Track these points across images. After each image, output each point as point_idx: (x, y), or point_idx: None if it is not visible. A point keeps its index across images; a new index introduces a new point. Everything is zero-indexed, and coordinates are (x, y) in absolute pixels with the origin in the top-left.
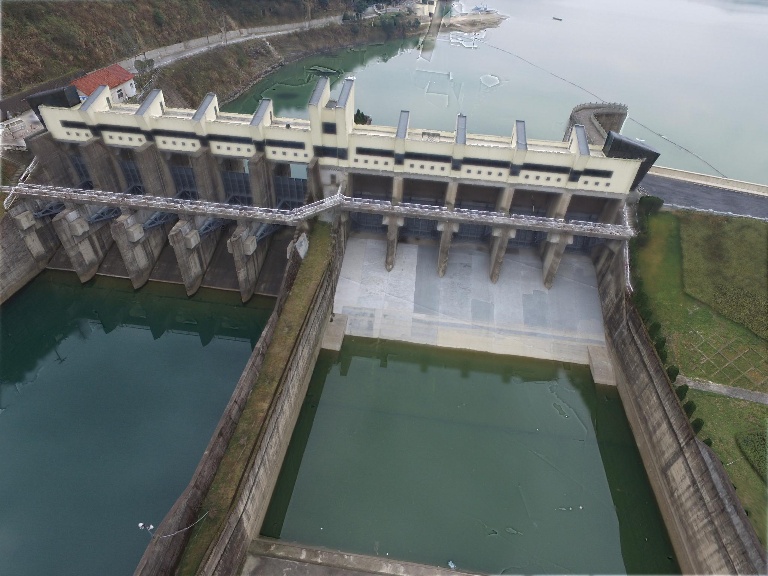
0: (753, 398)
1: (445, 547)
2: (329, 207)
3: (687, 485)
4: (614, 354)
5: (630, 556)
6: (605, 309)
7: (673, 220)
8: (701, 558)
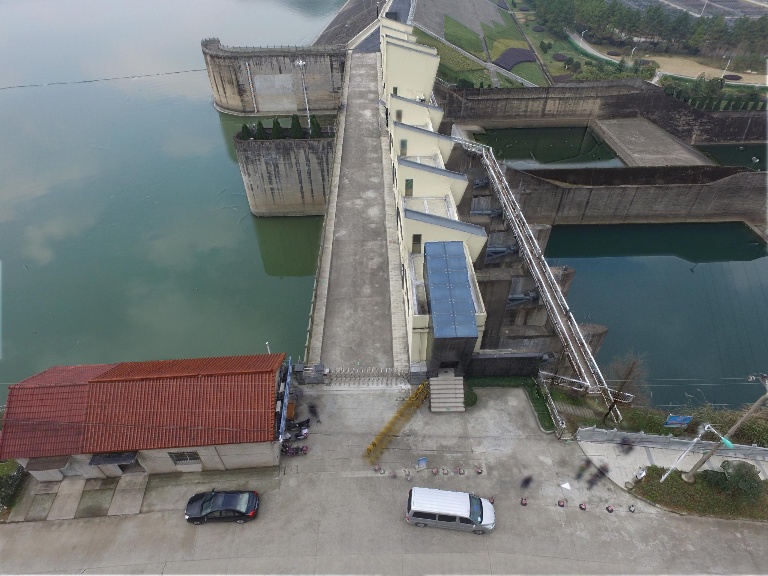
0: (498, 86)
1: None
2: None
3: (558, 103)
4: (469, 121)
5: None
6: None
7: None
8: None
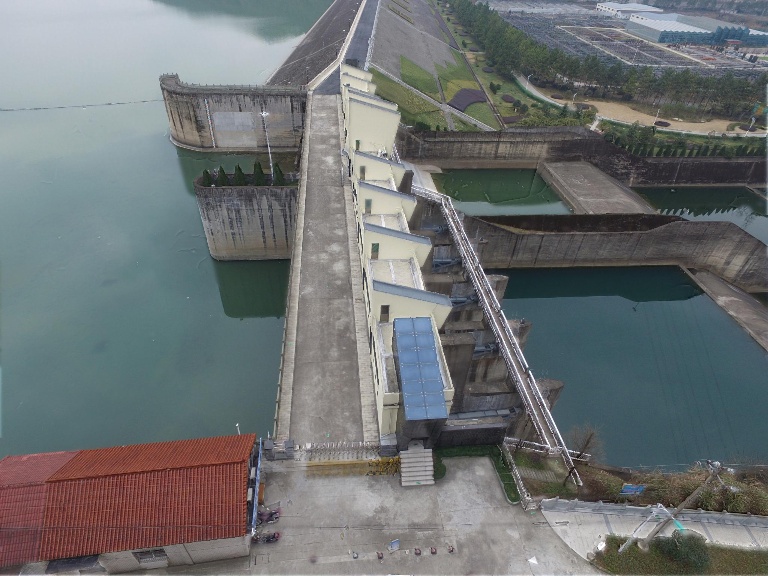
0: None
1: (565, 212)
2: (418, 192)
3: None
4: (427, 161)
5: (501, 200)
6: None
7: None
8: (529, 155)
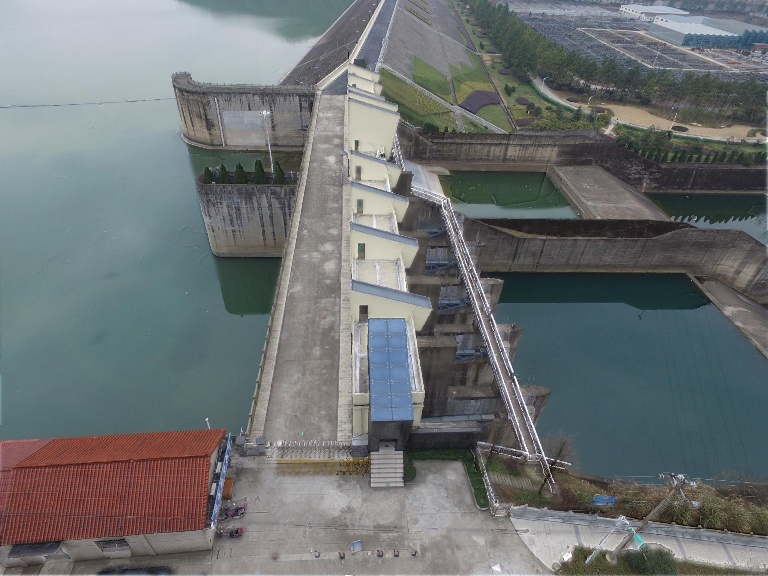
0: (463, 129)
1: None
2: None
3: (519, 149)
4: (434, 162)
5: (510, 203)
6: (405, 155)
7: (381, 93)
8: (539, 158)
